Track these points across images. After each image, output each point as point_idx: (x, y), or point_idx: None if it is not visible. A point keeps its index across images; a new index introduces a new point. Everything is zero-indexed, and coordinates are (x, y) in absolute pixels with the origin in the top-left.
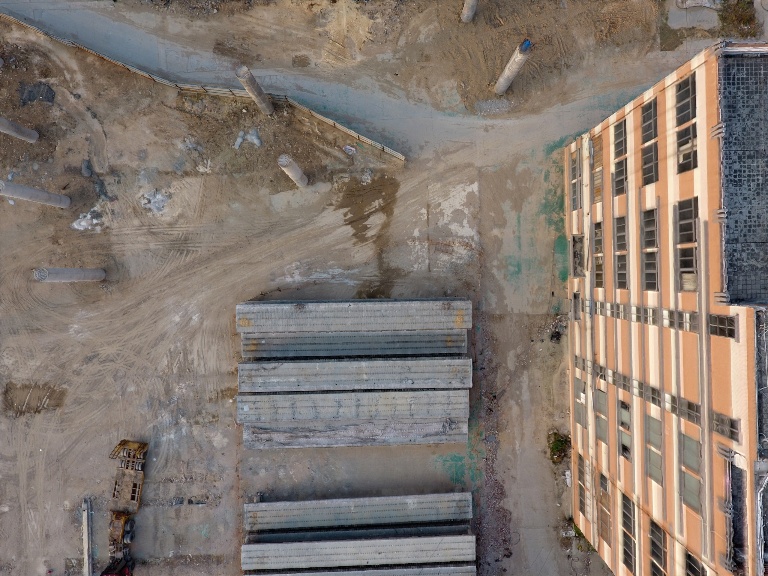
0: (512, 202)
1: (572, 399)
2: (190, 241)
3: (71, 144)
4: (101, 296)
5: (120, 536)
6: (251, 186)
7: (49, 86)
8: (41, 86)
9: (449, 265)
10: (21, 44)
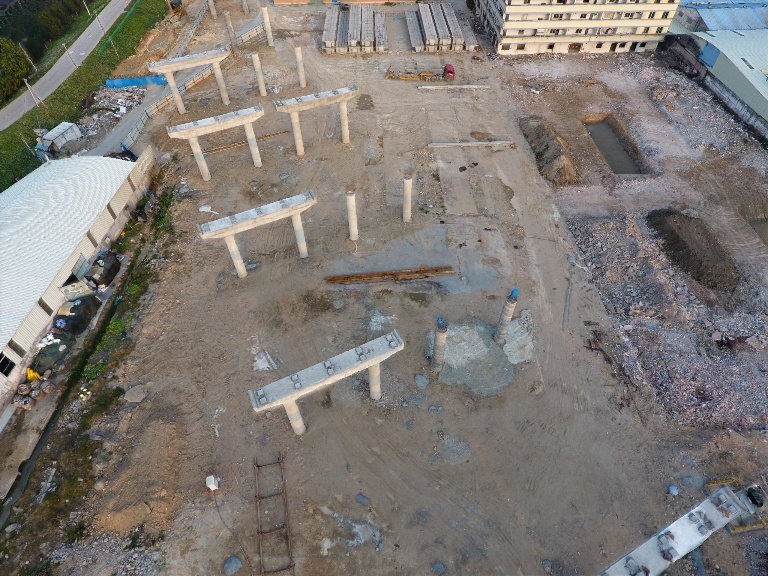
0: (292, 11)
1: (370, 1)
2: (292, 67)
3: (235, 93)
4: (314, 86)
5: (430, 71)
6: (270, 55)
7: (202, 99)
8: (201, 101)
9: (315, 20)
10: (176, 106)
